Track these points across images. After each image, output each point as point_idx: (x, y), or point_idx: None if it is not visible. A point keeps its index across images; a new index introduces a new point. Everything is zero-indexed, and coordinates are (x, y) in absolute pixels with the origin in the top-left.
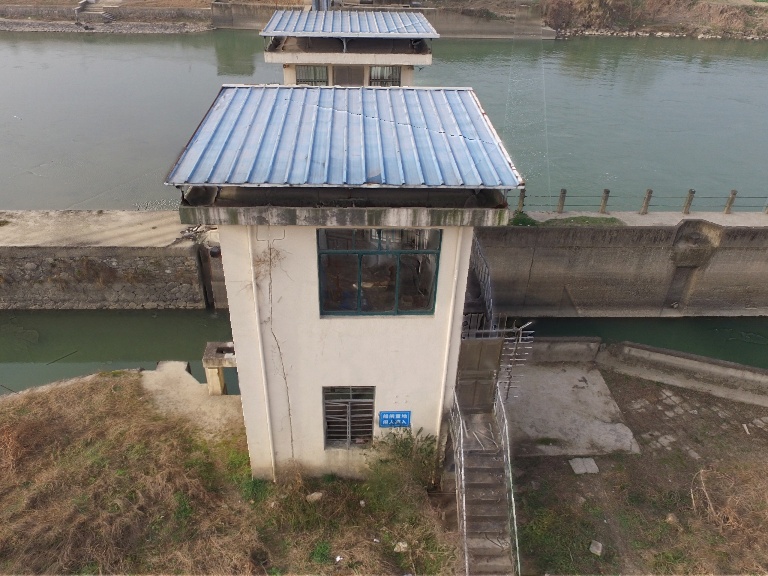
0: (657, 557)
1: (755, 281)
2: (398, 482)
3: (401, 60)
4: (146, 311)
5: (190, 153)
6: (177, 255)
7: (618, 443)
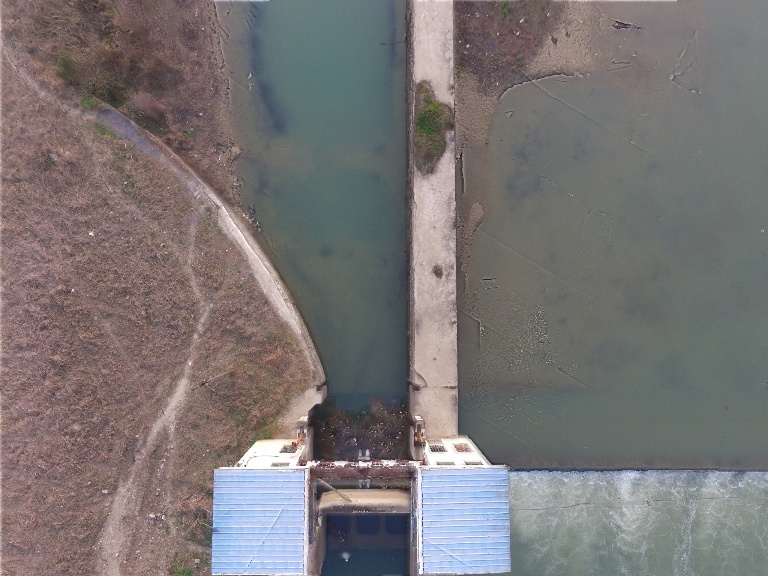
0: None
1: None
2: None
3: None
4: None
5: (236, 471)
6: None
7: None
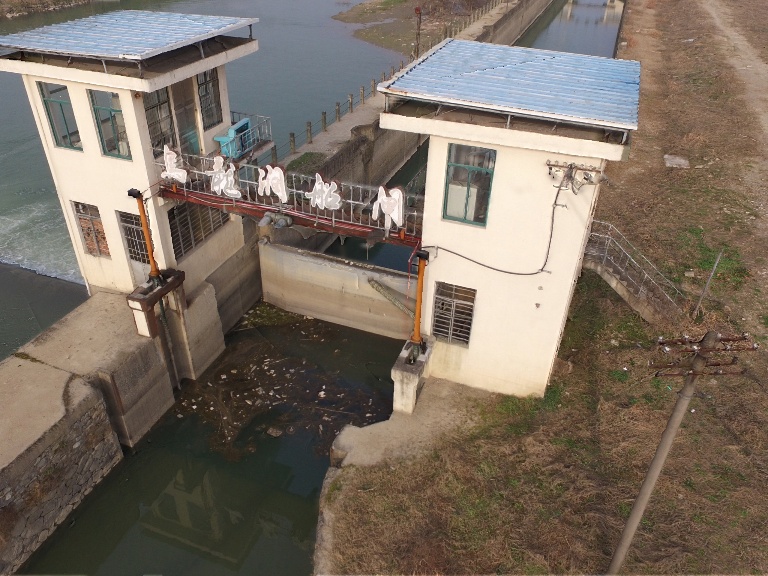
0: None
1: (387, 155)
2: (591, 311)
3: (242, 52)
4: (60, 528)
5: None
6: (83, 413)
7: None
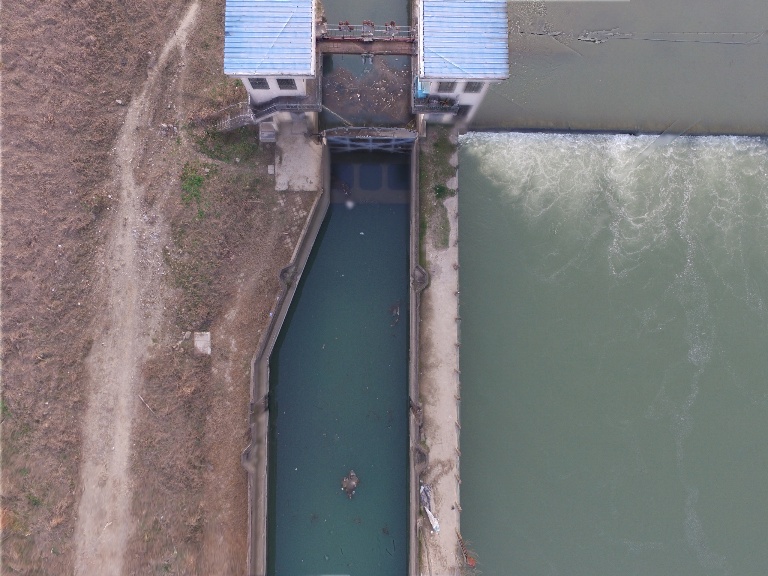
0: (234, 176)
1: None
2: None
3: None
4: None
5: None
6: None
7: (279, 183)
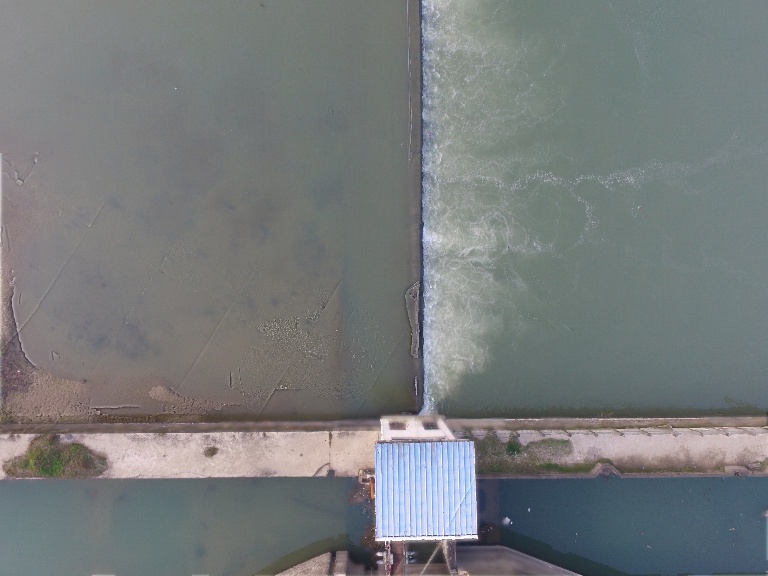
0: None
1: None
2: None
3: None
4: None
5: None
6: None
7: None
